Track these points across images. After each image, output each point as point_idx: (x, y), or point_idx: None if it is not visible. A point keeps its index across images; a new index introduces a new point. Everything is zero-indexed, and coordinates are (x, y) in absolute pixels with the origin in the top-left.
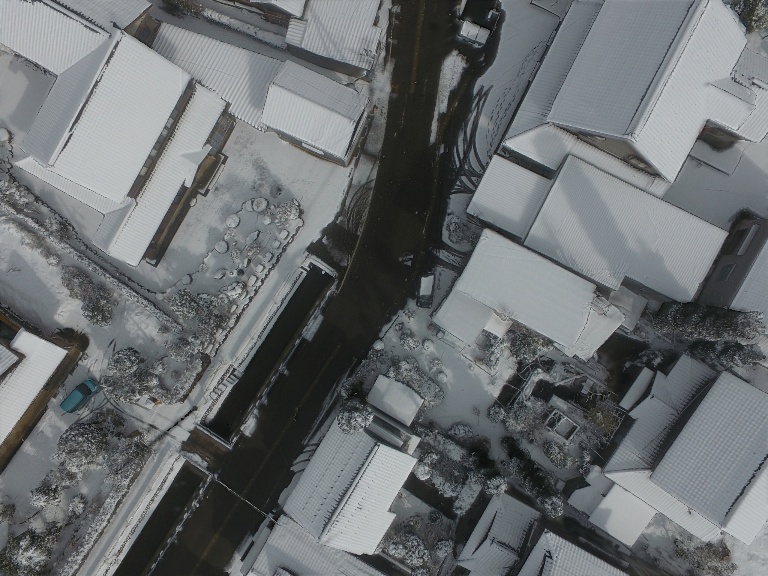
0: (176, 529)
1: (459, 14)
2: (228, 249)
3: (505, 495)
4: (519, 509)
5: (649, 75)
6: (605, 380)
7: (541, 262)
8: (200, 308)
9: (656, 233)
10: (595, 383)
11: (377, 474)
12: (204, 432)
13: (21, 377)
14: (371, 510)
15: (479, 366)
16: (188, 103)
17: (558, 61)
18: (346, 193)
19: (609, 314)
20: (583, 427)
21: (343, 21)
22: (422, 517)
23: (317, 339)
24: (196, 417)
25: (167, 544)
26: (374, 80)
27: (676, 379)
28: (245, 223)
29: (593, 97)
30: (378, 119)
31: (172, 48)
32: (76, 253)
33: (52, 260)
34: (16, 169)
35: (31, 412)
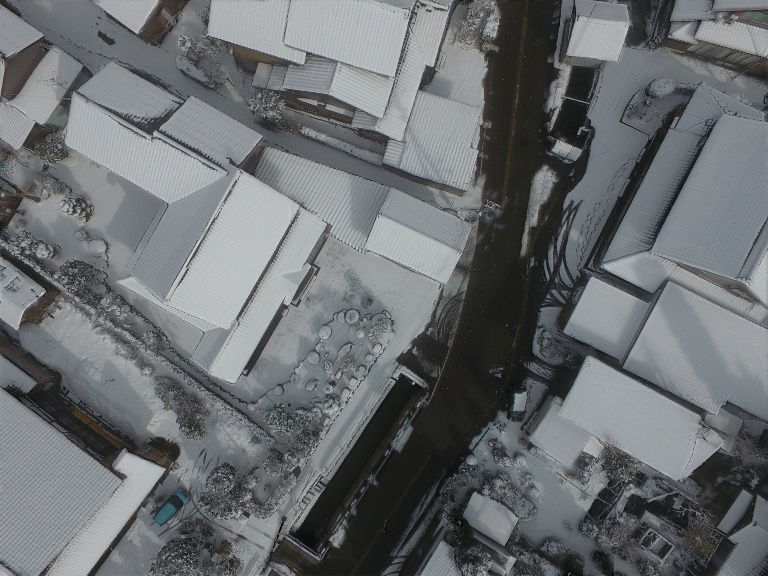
0: None
1: (549, 131)
2: (320, 360)
3: None
4: None
5: (760, 219)
6: (697, 496)
7: (645, 391)
8: (296, 424)
9: (762, 366)
10: (687, 499)
11: None
12: (293, 543)
13: (121, 496)
14: None
15: (573, 484)
16: (291, 226)
17: (656, 188)
18: (436, 305)
19: (708, 438)
20: (677, 545)
21: (441, 143)
22: None
23: (407, 450)
24: (286, 528)
25: None
26: (465, 194)
27: None
28: (337, 334)
29: (701, 235)
30: None
31: (275, 171)
32: (172, 366)
33: (146, 371)
34: (111, 278)
35: None
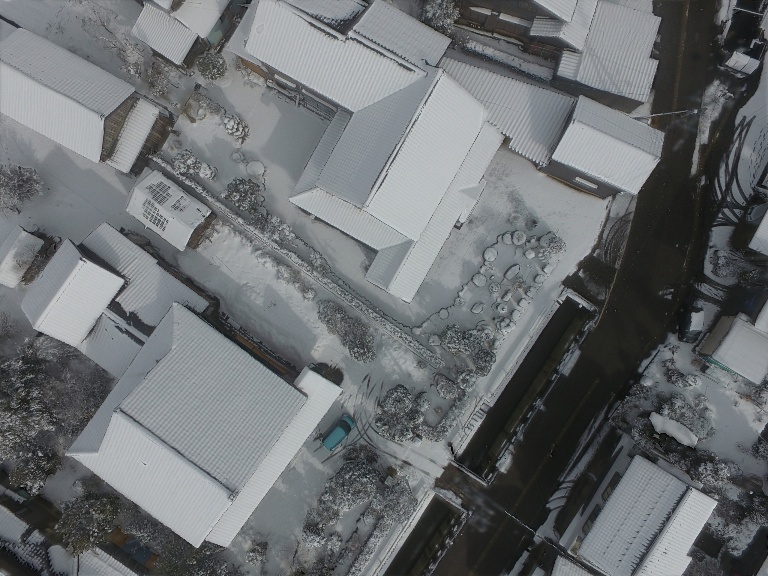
0: (430, 567)
1: None
2: None
3: None
4: None
5: None
6: None
7: None
8: (471, 344)
9: None
10: None
11: (684, 518)
12: None
13: (301, 416)
14: (674, 554)
15: (753, 403)
16: None
17: None
18: (603, 225)
19: None
20: None
21: (619, 53)
22: None
23: (574, 374)
24: None
25: None
26: (633, 111)
27: None
28: (502, 256)
29: None
30: None
31: None
32: (339, 288)
33: (310, 295)
34: (268, 202)
35: None
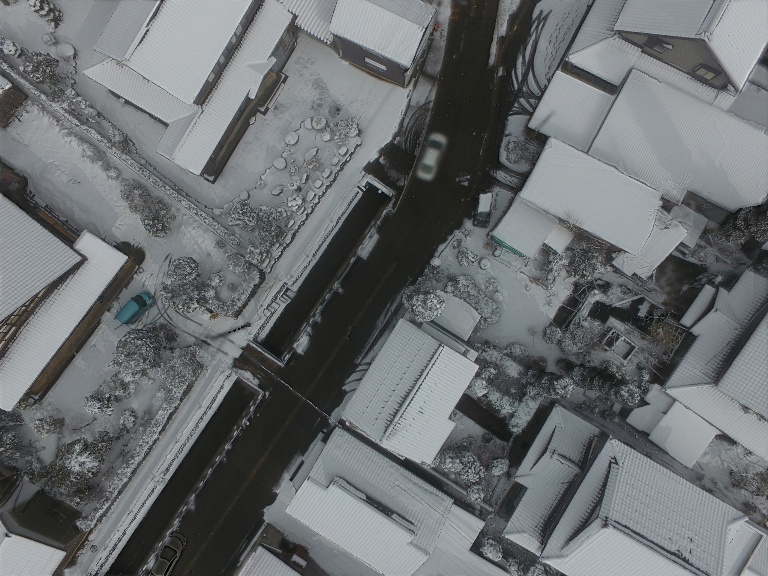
0: (226, 447)
1: None
2: (286, 166)
3: (564, 410)
4: (578, 424)
5: None
6: (662, 303)
7: (606, 170)
8: (260, 219)
9: (723, 141)
10: (652, 305)
11: (440, 377)
12: (257, 349)
13: (82, 280)
14: (432, 415)
15: (537, 283)
16: (256, 13)
17: None
18: (404, 114)
19: (671, 229)
20: (640, 348)
21: None
22: (475, 438)
23: (372, 258)
24: (249, 333)
25: (216, 462)
26: (434, 4)
27: (739, 294)
28: (303, 141)
29: (662, 3)
30: (437, 42)
31: None
32: (137, 165)
33: (112, 173)
34: (79, 85)
35: (85, 324)
